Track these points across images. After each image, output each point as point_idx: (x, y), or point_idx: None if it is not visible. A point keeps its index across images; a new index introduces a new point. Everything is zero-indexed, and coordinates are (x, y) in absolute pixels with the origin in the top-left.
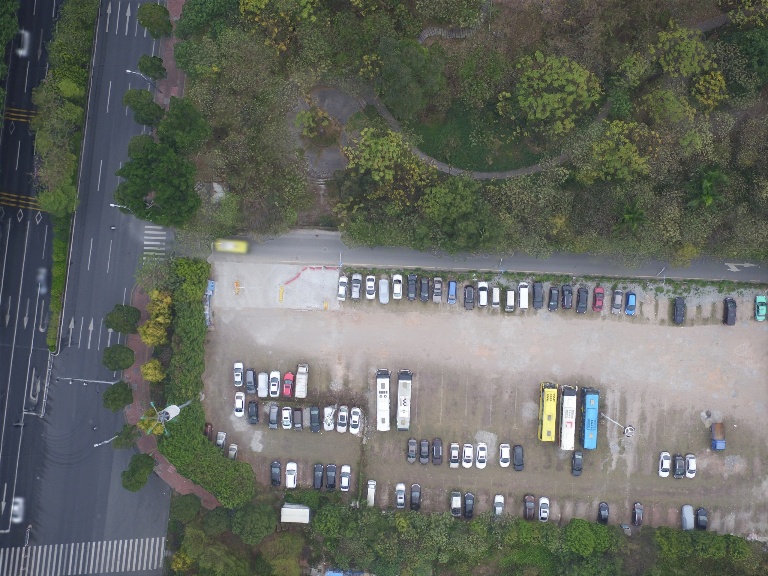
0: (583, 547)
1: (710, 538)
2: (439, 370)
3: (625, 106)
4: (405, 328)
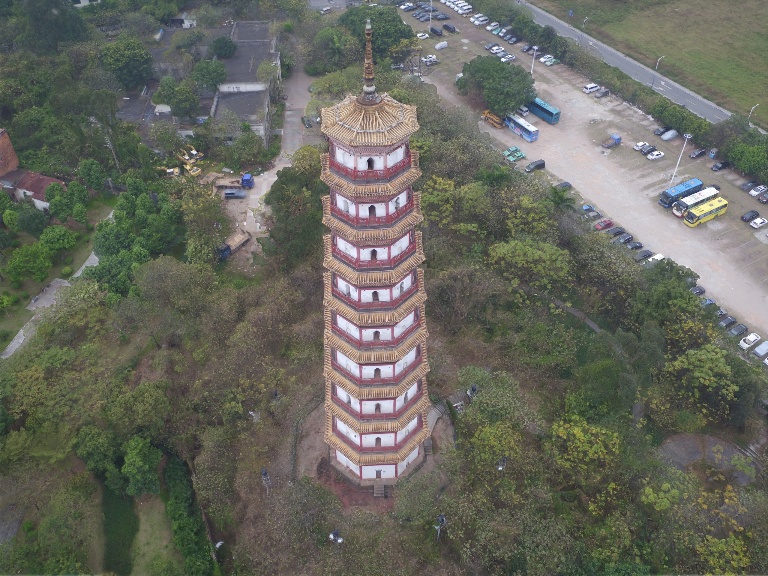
0: (760, 150)
1: (672, 116)
2: (763, 285)
3: (477, 247)
4: (767, 321)
